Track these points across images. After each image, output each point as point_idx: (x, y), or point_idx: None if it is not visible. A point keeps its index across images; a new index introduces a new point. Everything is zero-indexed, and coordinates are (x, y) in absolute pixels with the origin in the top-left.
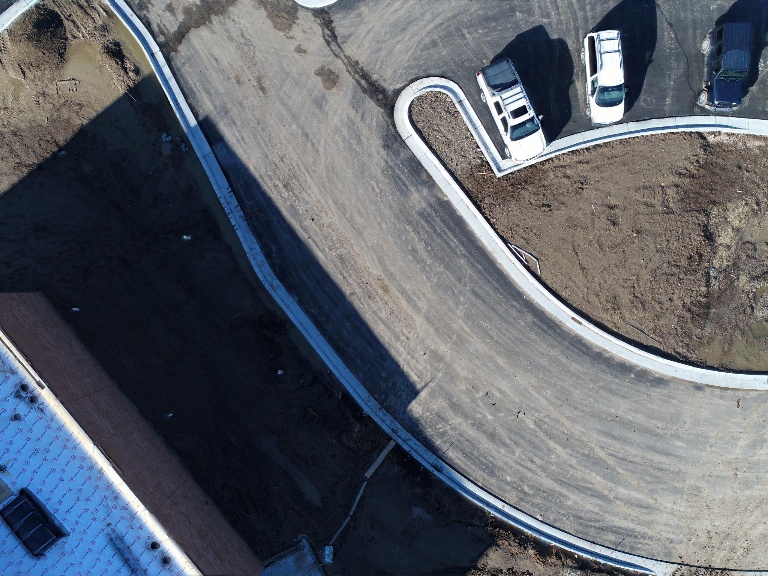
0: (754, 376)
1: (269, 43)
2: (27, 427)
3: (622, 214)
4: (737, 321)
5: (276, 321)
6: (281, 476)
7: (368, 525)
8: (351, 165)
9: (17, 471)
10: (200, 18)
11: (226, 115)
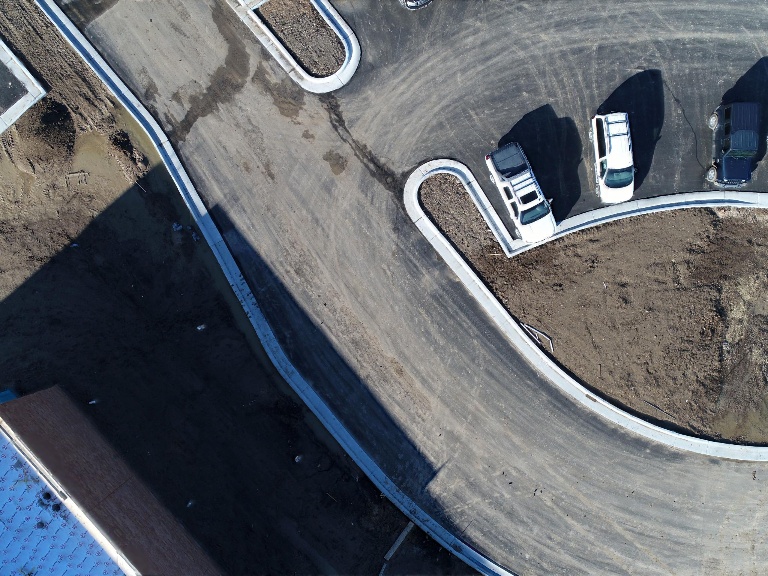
0: None
1: (277, 129)
2: (50, 535)
3: (634, 291)
4: (751, 394)
5: (291, 406)
6: (301, 561)
7: None
8: (362, 249)
9: None
10: (207, 107)
11: (236, 203)
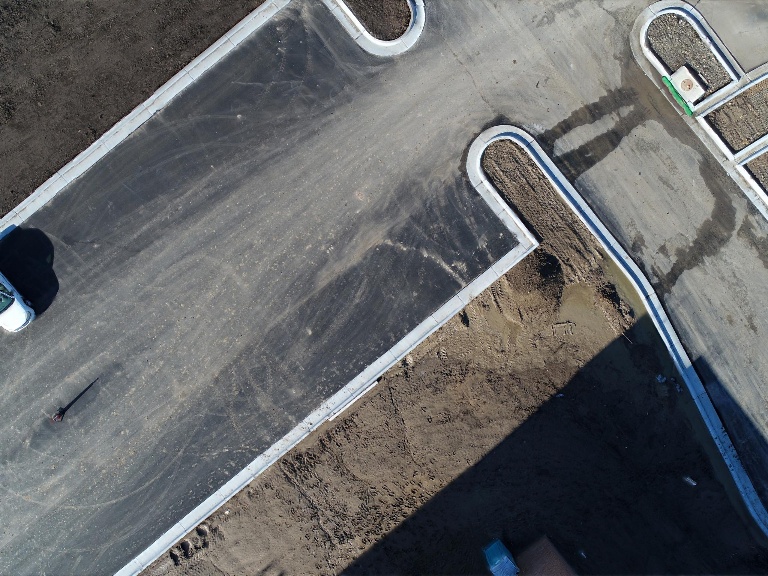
0: None
1: (761, 283)
2: None
3: None
4: None
5: None
6: None
7: None
8: None
9: None
10: (693, 259)
11: (719, 355)
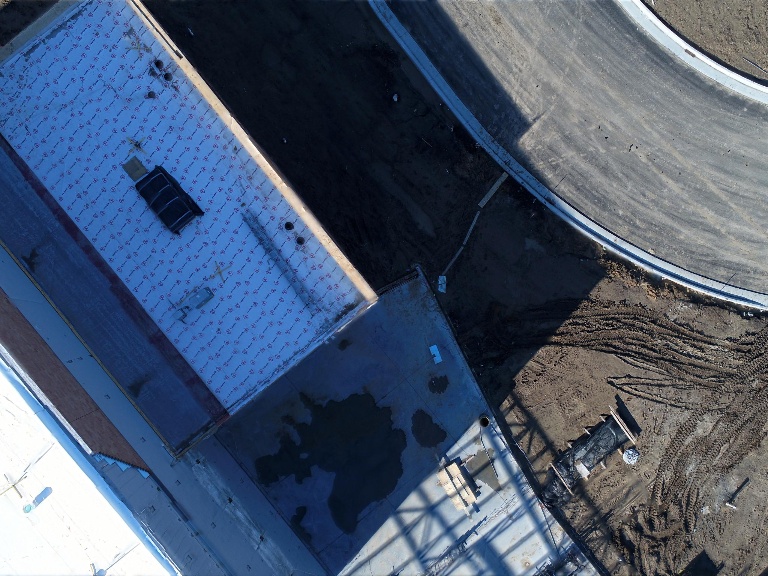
0: None
1: None
2: (161, 105)
3: None
4: None
5: (389, 52)
6: (394, 206)
7: (481, 255)
8: None
9: (151, 149)
10: None
11: None
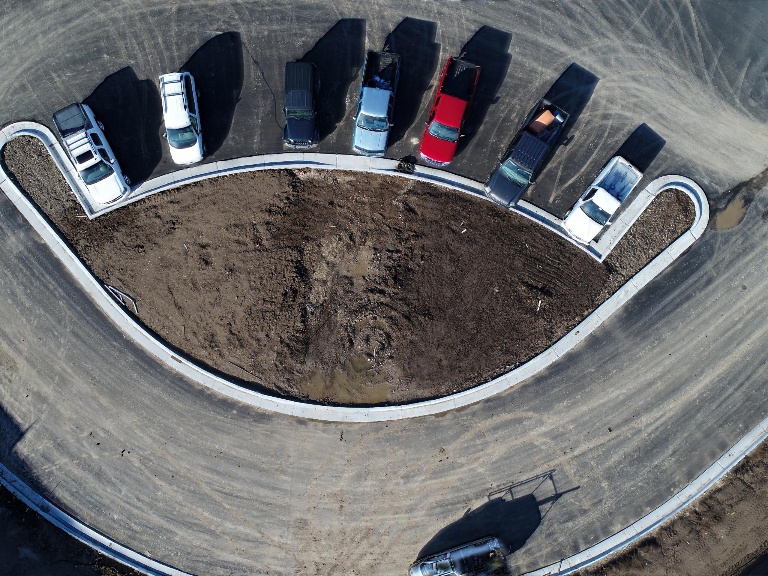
0: (355, 409)
1: None
2: None
3: (214, 253)
4: (337, 355)
5: None
6: None
7: None
8: None
9: None
10: None
11: None
